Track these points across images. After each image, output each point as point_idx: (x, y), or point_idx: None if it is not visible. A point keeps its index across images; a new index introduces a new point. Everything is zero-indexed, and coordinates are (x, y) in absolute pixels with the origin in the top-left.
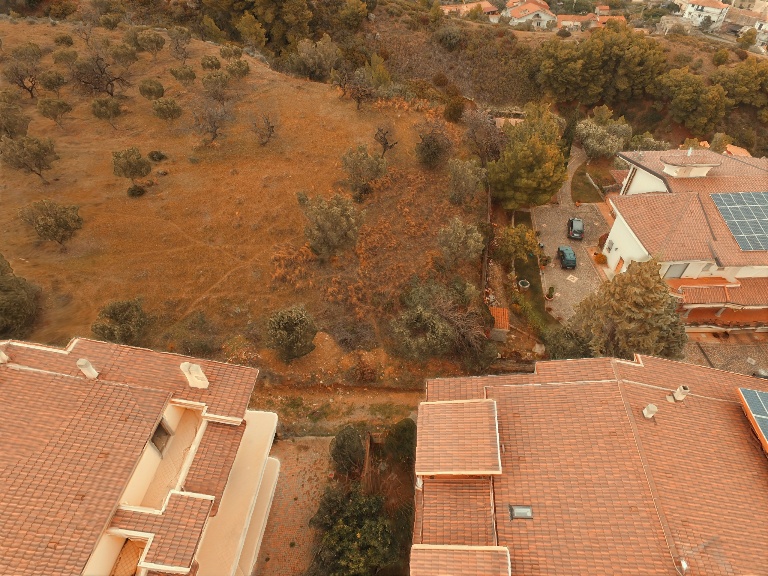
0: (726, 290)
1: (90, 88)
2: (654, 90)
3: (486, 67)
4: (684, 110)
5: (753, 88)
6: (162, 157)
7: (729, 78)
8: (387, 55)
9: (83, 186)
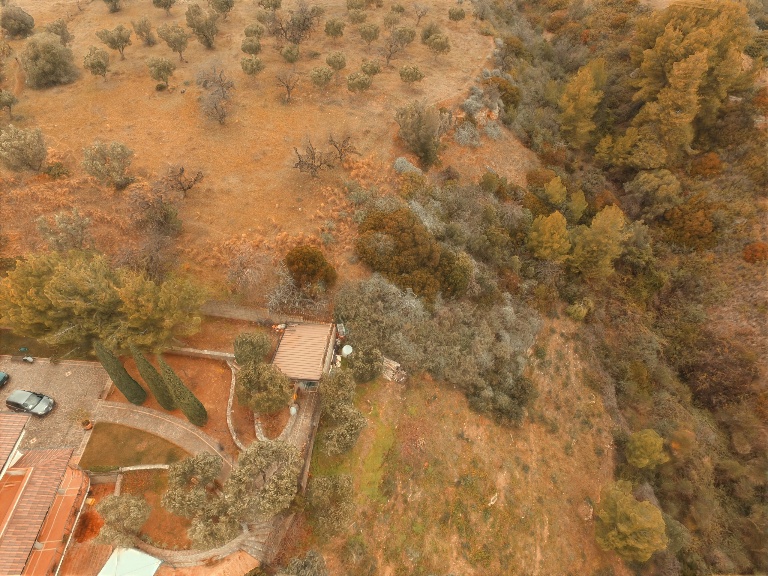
0: None
1: (279, 32)
2: None
3: None
4: None
5: None
6: None
7: None
8: (757, 257)
9: (175, 71)
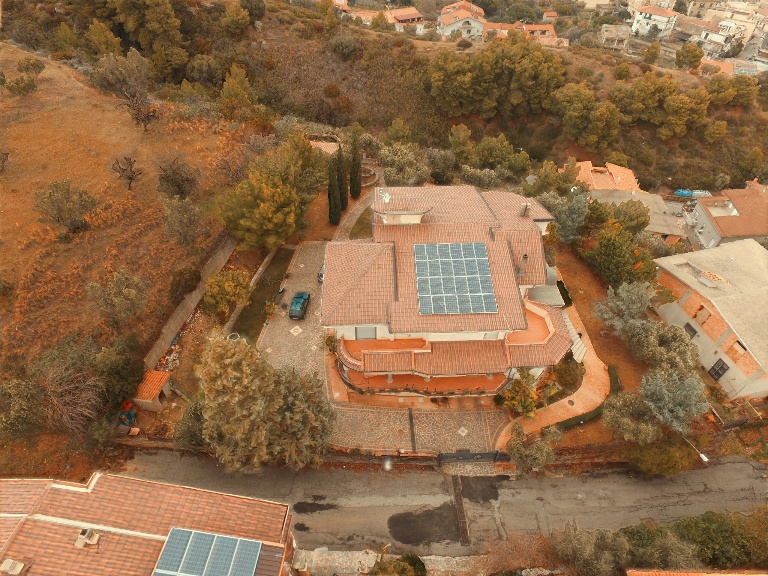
0: (412, 356)
1: None
2: (551, 105)
3: (382, 78)
4: (575, 127)
5: (650, 105)
6: None
7: (626, 94)
8: (272, 65)
9: None
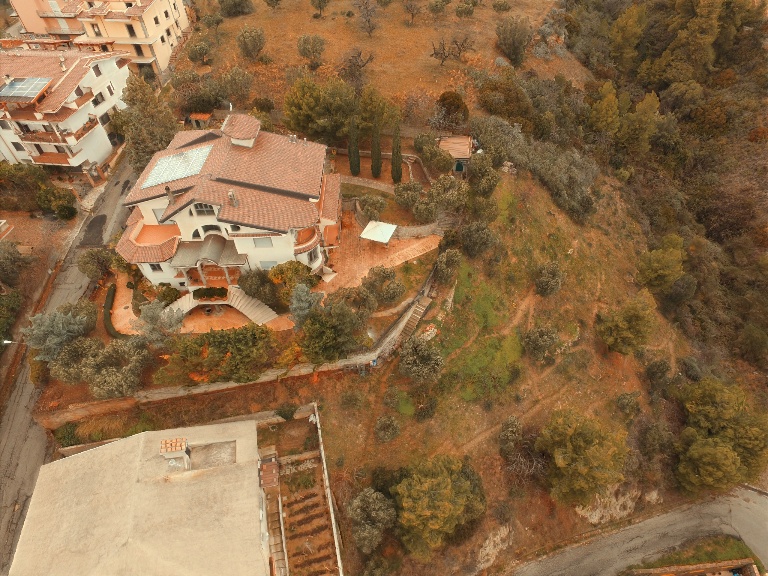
0: None
1: None
2: None
3: None
4: None
5: None
6: (349, 15)
7: None
8: (759, 137)
9: None
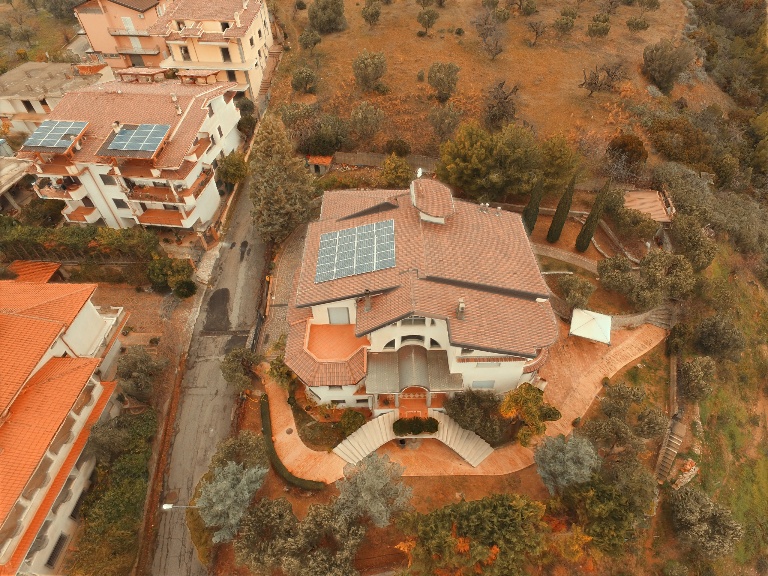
0: None
1: None
2: None
3: None
4: None
5: None
6: (459, 33)
7: None
8: None
9: None
